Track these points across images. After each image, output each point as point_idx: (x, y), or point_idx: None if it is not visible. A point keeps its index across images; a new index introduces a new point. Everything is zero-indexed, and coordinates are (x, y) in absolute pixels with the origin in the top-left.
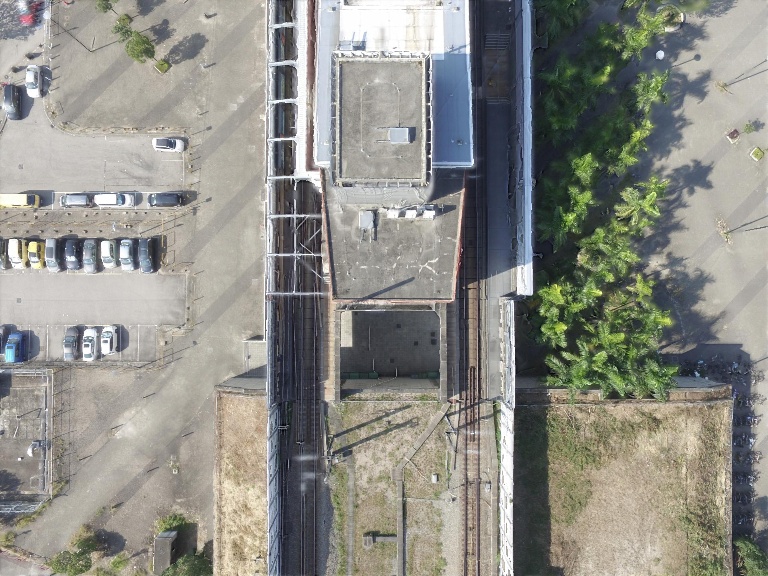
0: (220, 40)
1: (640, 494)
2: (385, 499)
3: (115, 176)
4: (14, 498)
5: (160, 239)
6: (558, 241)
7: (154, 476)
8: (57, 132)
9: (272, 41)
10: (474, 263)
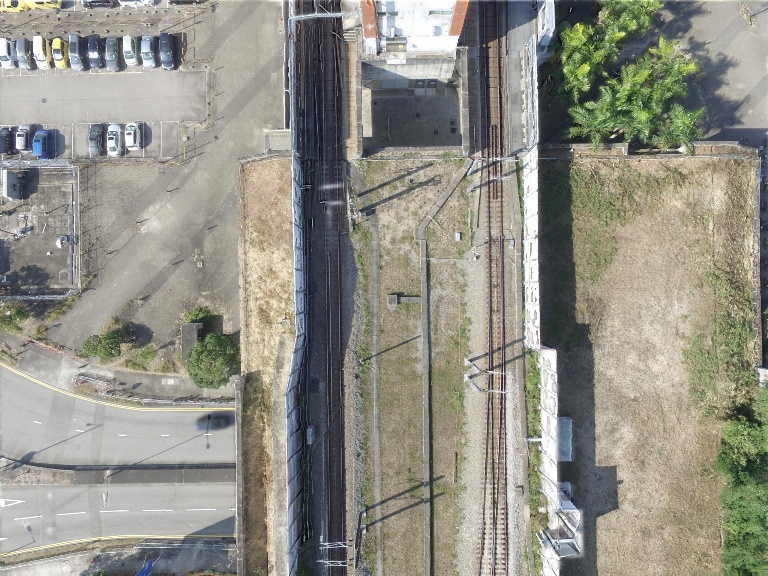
0: None
1: (666, 250)
2: (409, 261)
3: None
4: (44, 292)
5: (180, 37)
6: None
7: (179, 269)
8: None
9: None
10: (494, 21)
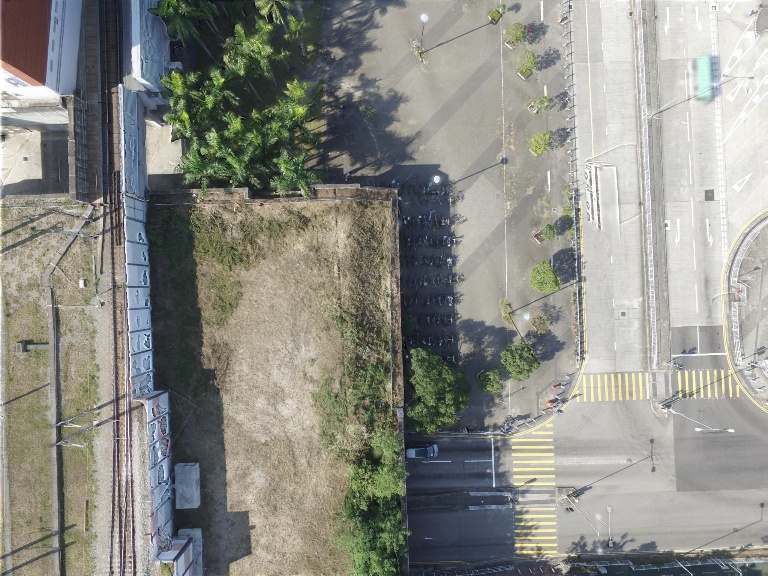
0: None
1: (291, 294)
2: (38, 308)
3: None
4: None
5: None
6: (180, 31)
7: None
8: None
9: None
10: (116, 67)
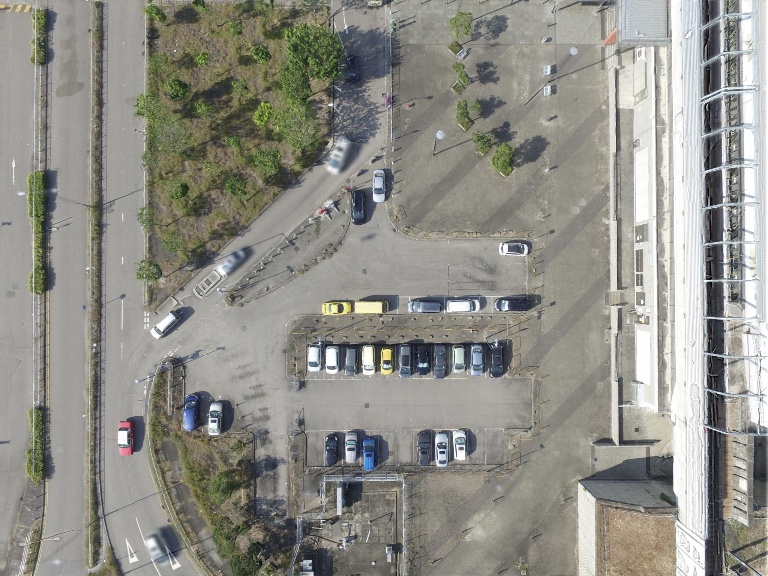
0: (561, 143)
1: None
2: None
3: (458, 280)
4: None
5: (505, 343)
6: None
7: None
8: (400, 236)
9: (705, 173)
10: None
